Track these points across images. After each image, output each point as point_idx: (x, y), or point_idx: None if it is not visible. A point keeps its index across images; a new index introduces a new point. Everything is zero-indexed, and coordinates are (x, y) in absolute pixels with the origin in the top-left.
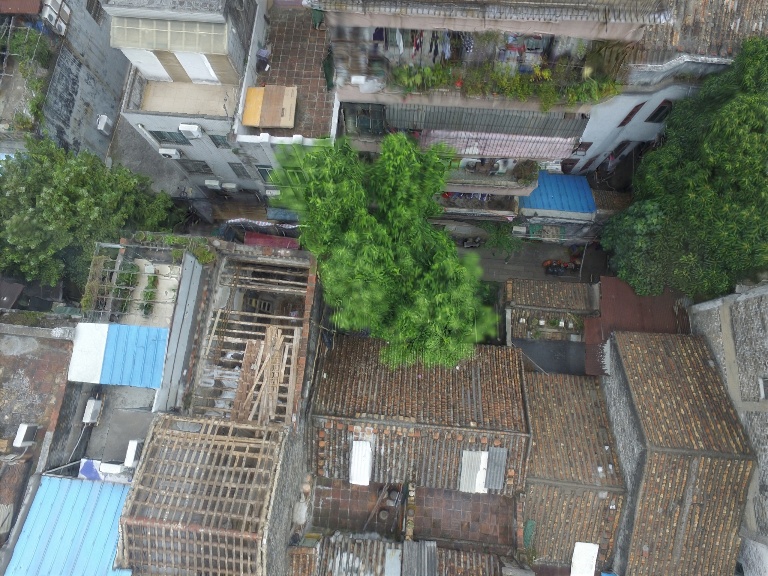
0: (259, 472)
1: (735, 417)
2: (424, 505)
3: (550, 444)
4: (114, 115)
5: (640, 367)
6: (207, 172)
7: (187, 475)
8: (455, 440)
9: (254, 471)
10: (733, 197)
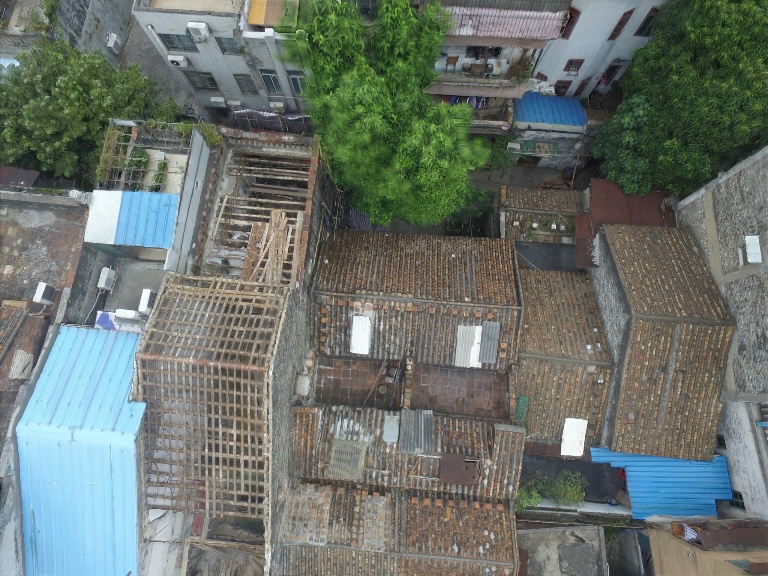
0: (265, 318)
1: (716, 291)
2: (421, 383)
3: (541, 327)
4: (123, 38)
5: (627, 252)
6: (213, 88)
7: (197, 320)
8: (450, 315)
9: (260, 318)
10: (714, 76)
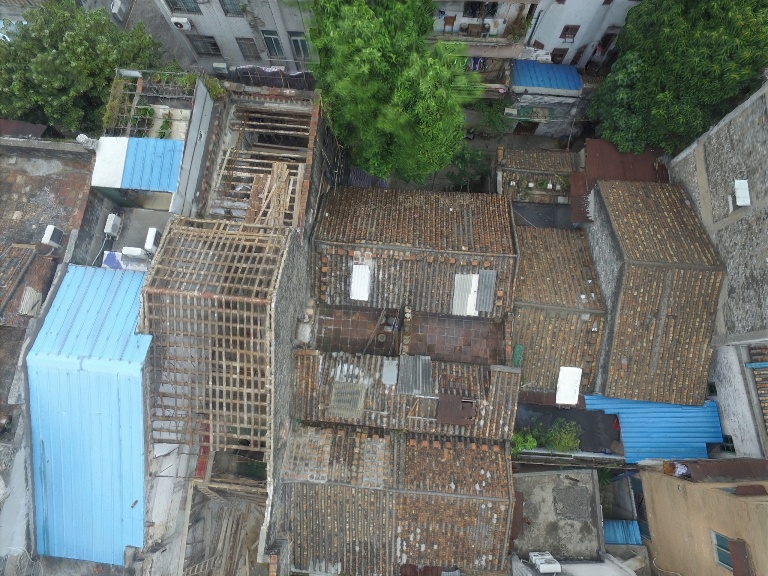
0: (267, 256)
1: (707, 240)
2: (419, 332)
3: (537, 278)
4: (127, 6)
5: (621, 205)
6: (215, 53)
7: (202, 258)
8: (448, 264)
9: (263, 255)
10: (704, 27)
